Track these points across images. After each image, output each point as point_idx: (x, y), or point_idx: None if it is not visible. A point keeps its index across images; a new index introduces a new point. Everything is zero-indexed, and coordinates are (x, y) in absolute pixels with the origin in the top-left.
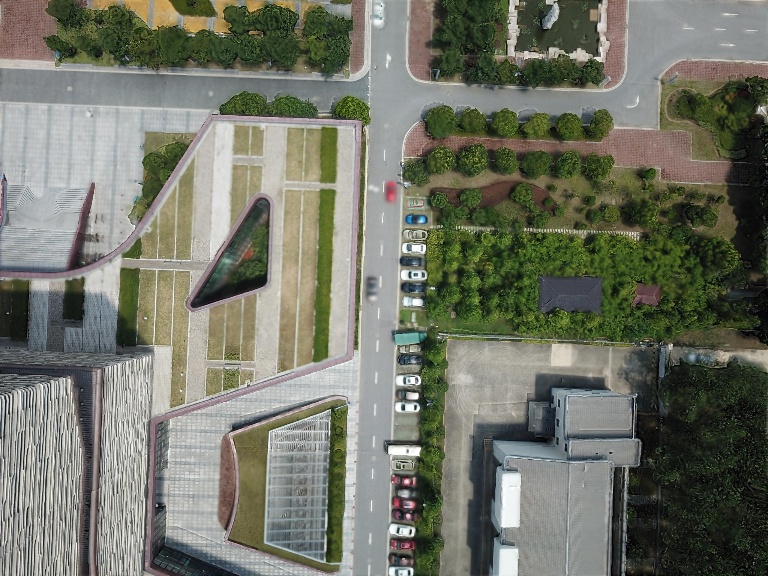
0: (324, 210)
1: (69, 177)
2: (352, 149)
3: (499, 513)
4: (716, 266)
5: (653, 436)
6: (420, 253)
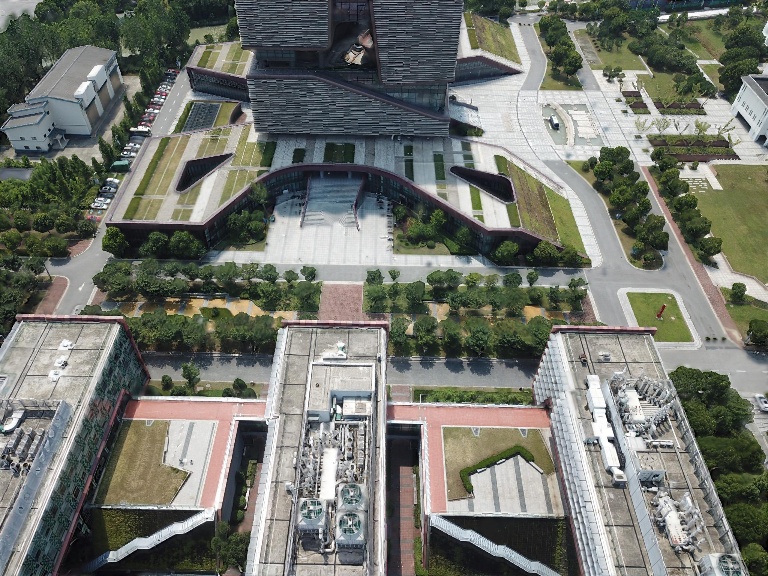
0: (144, 187)
1: (317, 231)
2: (117, 212)
3: None
4: None
5: (2, 138)
6: None
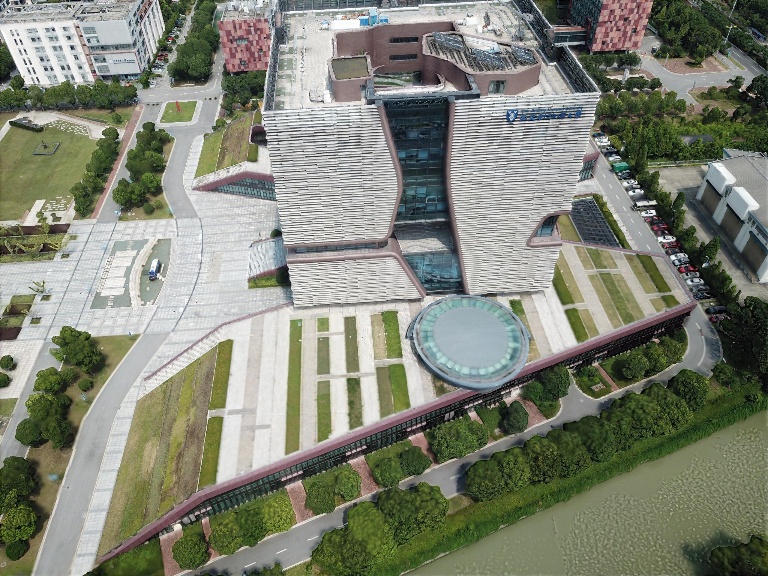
0: None
1: None
2: None
3: (721, 179)
4: (763, 120)
5: None
6: (607, 144)
